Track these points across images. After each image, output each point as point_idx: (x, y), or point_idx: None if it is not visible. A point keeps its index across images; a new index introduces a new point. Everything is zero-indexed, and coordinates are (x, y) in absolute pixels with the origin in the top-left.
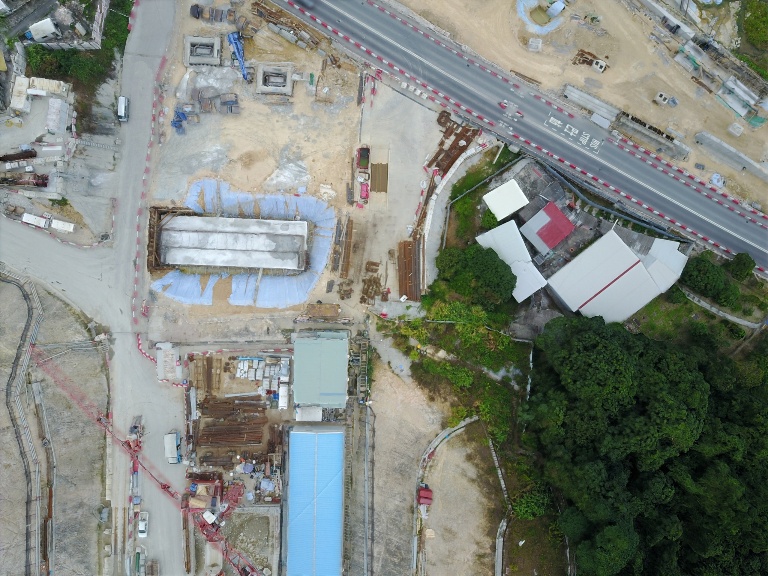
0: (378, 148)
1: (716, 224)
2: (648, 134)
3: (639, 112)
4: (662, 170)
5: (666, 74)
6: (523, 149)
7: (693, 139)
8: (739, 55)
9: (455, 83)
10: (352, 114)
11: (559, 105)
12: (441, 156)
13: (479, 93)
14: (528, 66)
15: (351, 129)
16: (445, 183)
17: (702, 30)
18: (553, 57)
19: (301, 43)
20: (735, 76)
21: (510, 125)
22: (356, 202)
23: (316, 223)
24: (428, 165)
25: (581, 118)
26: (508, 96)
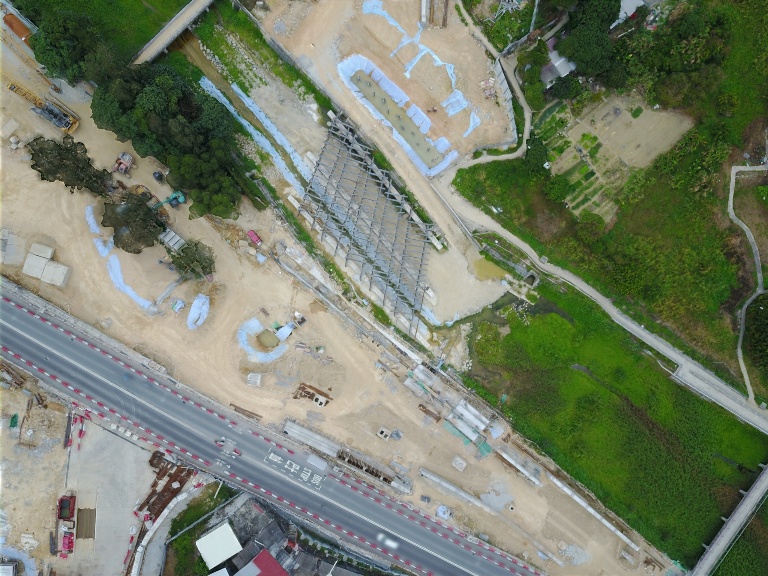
0: (86, 492)
1: (442, 557)
2: (365, 476)
3: (363, 445)
4: (385, 505)
5: (393, 402)
6: (240, 489)
7: (418, 472)
8: (468, 381)
9: (170, 421)
10: (58, 457)
11: (280, 441)
12: (154, 498)
13: (195, 431)
14: (248, 400)
15: (57, 473)
16: (152, 534)
17: (432, 354)
18: (274, 391)
19: (3, 384)
20: (466, 399)
21: (228, 463)
22: (60, 552)
23: (24, 565)
24: (139, 509)
25: (302, 453)
26: (226, 433)
